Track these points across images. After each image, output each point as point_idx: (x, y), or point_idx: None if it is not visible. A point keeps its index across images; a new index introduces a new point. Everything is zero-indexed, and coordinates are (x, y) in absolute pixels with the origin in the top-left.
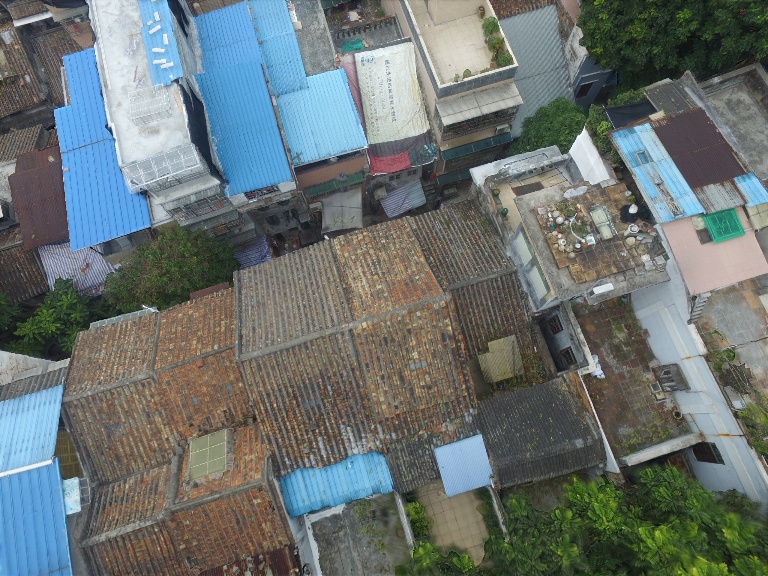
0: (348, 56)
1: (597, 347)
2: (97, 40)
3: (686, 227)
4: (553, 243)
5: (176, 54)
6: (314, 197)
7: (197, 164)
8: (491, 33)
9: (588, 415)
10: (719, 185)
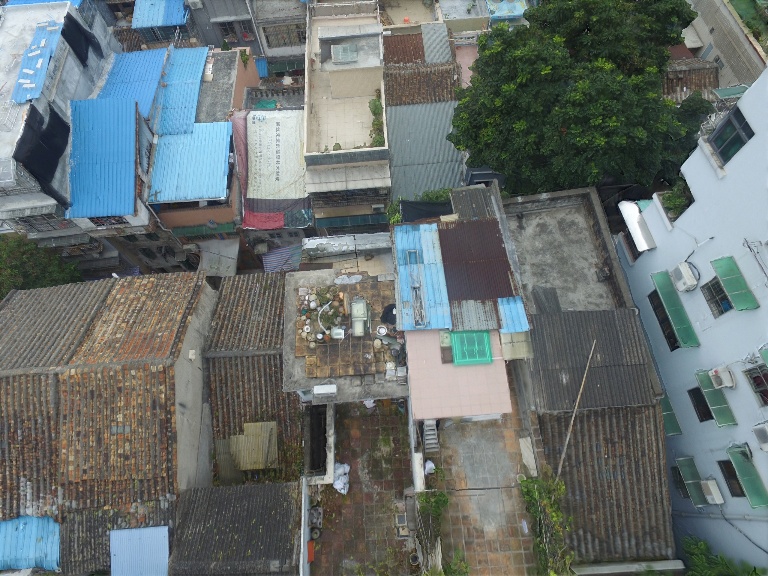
0: (244, 112)
1: (354, 456)
2: None
3: (431, 341)
4: (298, 328)
5: (42, 77)
6: (189, 238)
7: (10, 178)
8: (375, 114)
9: (299, 534)
10: (479, 302)
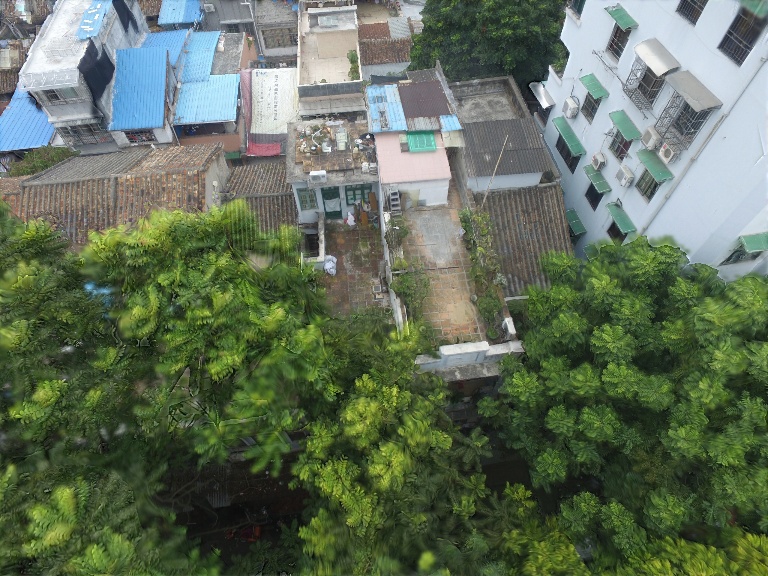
0: (249, 70)
1: (340, 254)
2: (53, 14)
3: (393, 140)
4: (297, 146)
5: (99, 25)
6: None
7: (75, 81)
8: (352, 63)
9: None
10: (427, 118)
